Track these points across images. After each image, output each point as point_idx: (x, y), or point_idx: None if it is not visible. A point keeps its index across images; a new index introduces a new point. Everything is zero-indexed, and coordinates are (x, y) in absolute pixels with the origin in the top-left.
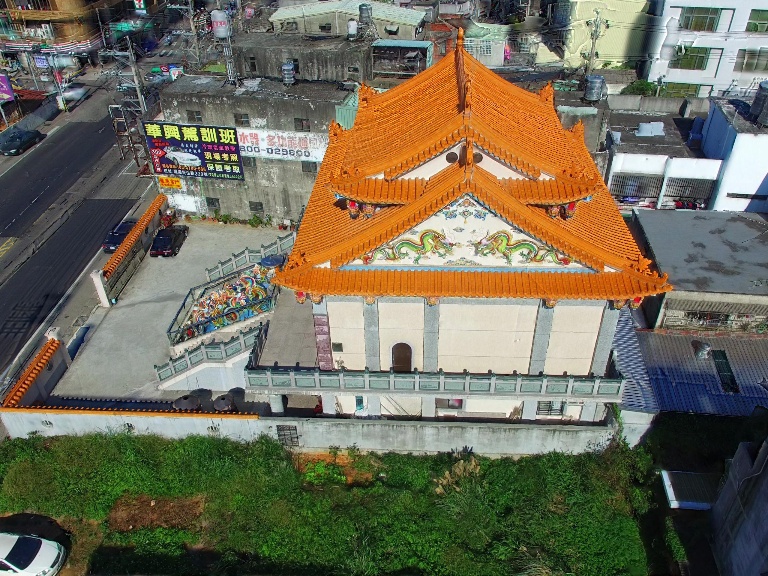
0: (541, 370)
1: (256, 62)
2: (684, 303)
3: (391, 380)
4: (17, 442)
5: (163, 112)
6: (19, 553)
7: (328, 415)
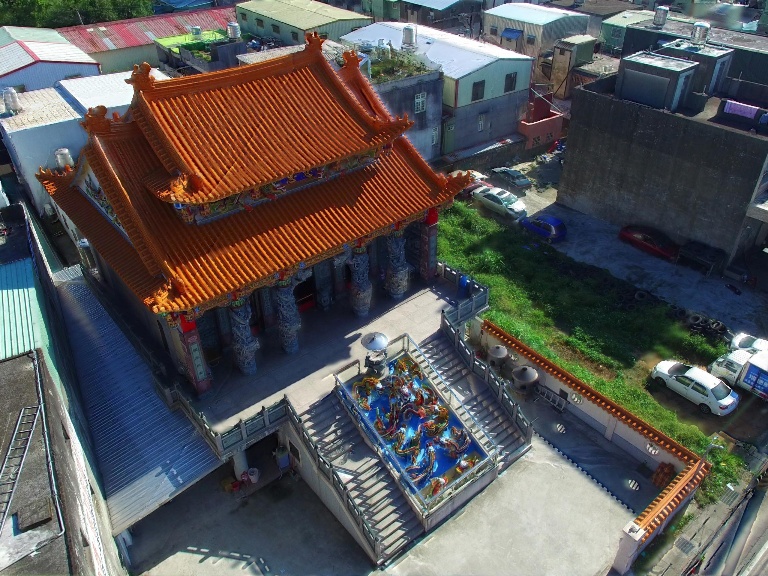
0: None
1: None
2: None
3: None
4: None
5: None
6: None
7: None
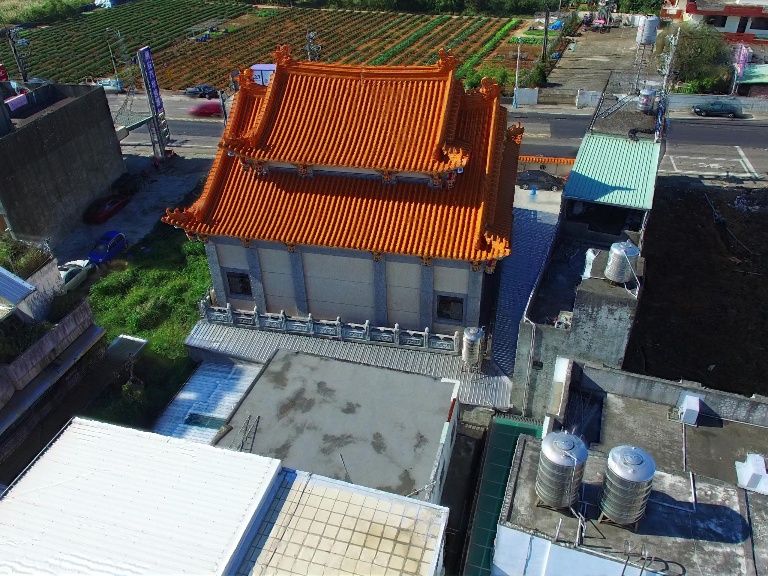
0: None
1: None
2: None
3: None
4: None
5: None
6: None
7: None
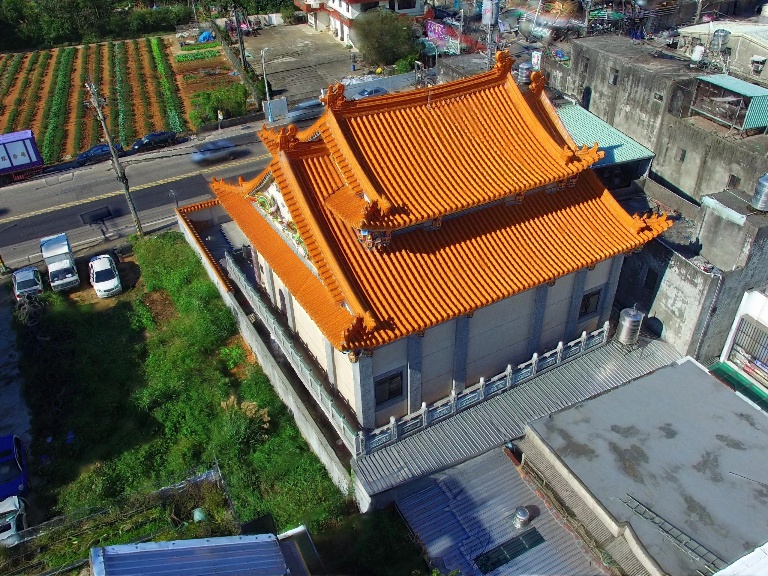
0: (333, 382)
1: (589, 64)
2: (535, 452)
3: (265, 313)
4: (175, 233)
5: (437, 77)
6: (105, 275)
7: (262, 322)
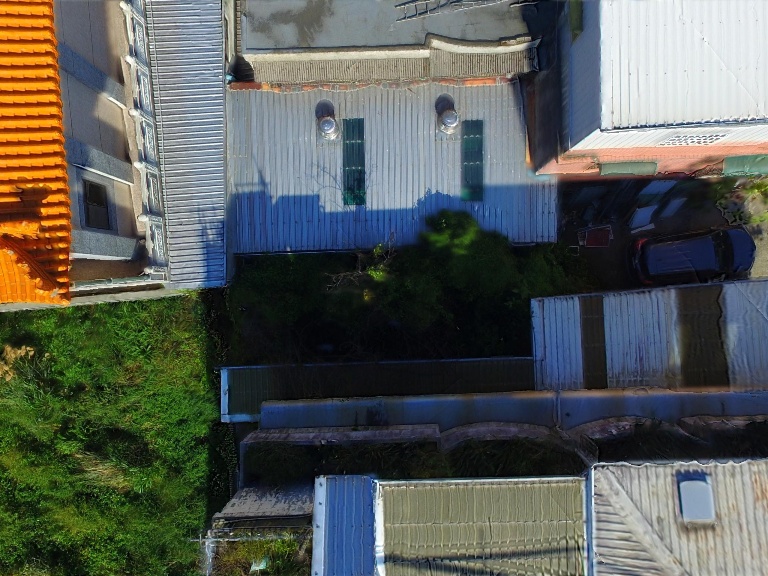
0: None
1: None
2: (280, 67)
3: None
4: None
5: None
6: None
7: None
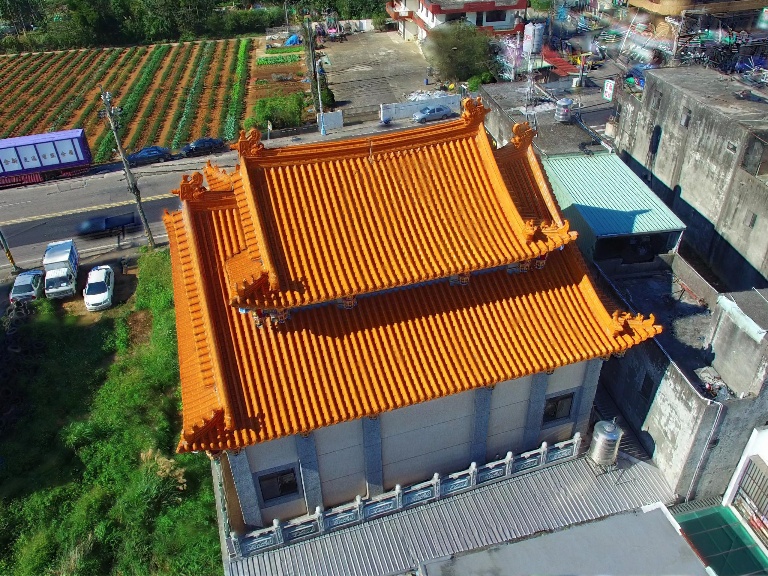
0: None
1: (661, 99)
2: None
3: None
4: None
5: None
6: (98, 288)
7: None
